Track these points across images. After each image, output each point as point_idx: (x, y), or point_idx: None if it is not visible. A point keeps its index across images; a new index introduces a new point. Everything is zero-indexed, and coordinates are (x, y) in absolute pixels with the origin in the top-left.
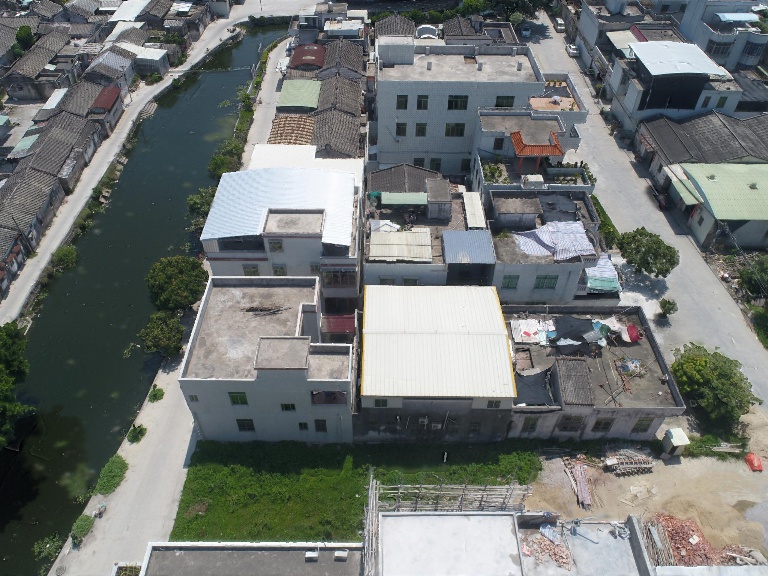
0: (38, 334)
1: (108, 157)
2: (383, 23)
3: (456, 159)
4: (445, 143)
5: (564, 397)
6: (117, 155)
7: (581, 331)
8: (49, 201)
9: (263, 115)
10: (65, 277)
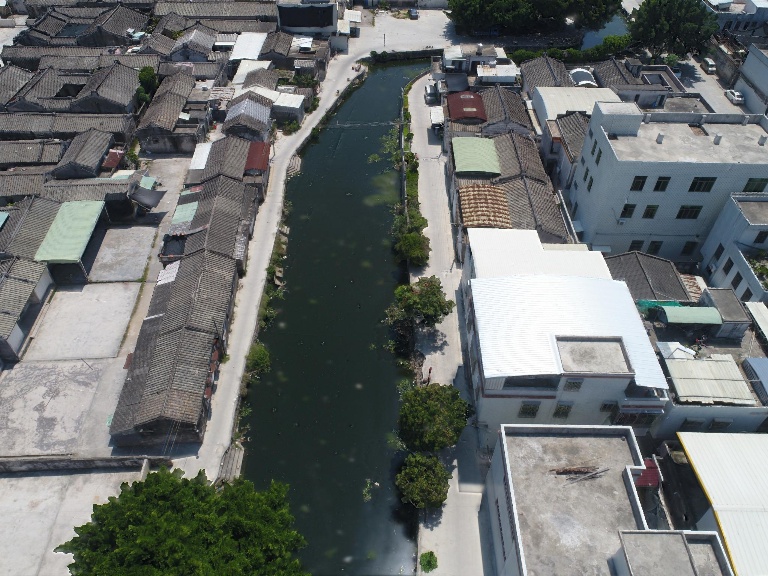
0: (255, 466)
1: (271, 227)
2: (532, 66)
3: (680, 242)
4: (673, 225)
5: None
6: (279, 224)
7: None
8: (231, 290)
9: (425, 175)
10: (264, 386)
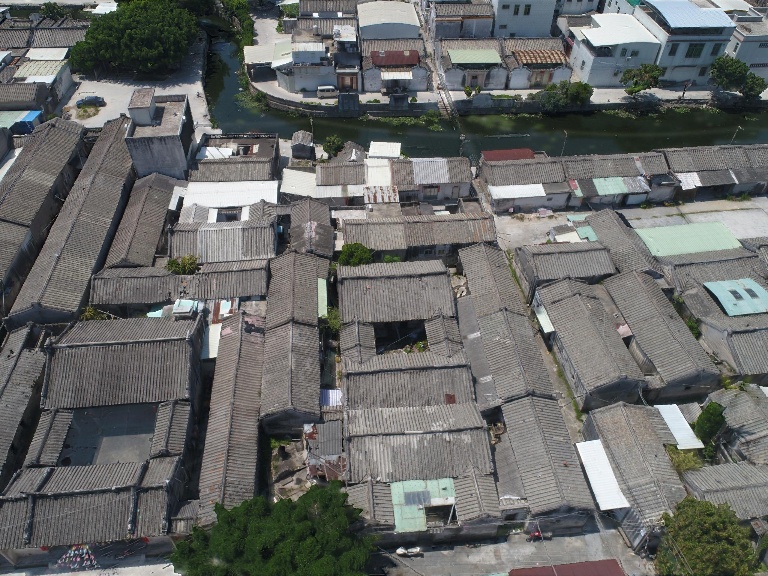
0: None
1: None
2: None
3: None
4: None
5: None
6: None
7: None
8: None
9: None
10: None
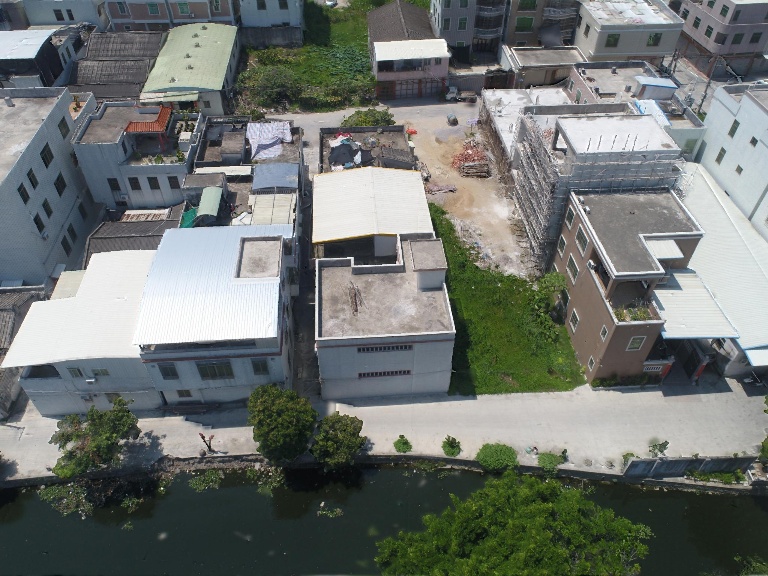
0: None
1: None
2: None
3: (76, 213)
4: (64, 205)
5: (409, 161)
6: None
7: (350, 149)
8: None
9: None
10: None
